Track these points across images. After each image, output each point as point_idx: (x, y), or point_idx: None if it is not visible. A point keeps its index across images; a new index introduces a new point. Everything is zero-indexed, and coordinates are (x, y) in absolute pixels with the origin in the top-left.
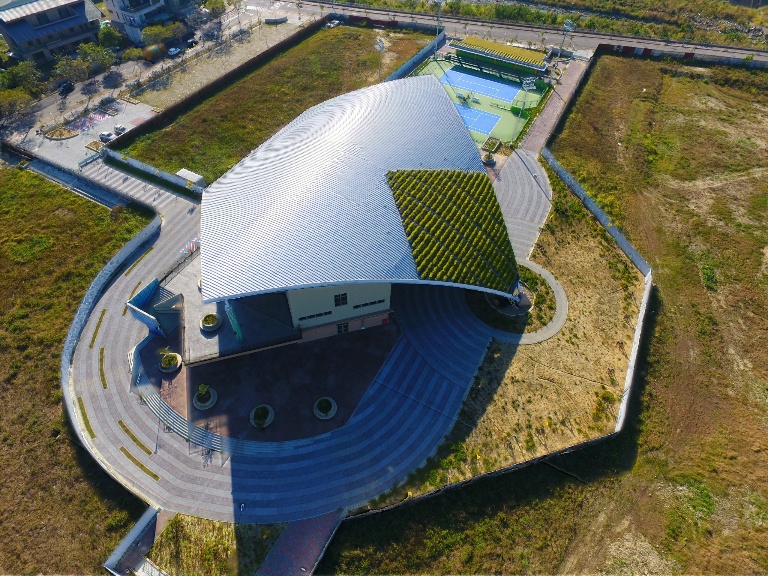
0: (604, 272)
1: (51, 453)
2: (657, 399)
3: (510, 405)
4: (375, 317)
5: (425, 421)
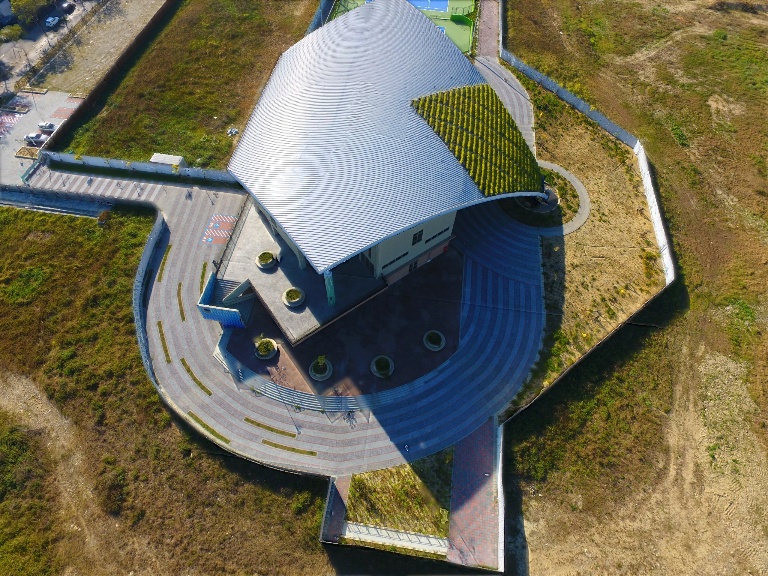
0: (601, 153)
1: (195, 471)
2: (684, 247)
3: (581, 287)
4: (439, 247)
5: (521, 323)
